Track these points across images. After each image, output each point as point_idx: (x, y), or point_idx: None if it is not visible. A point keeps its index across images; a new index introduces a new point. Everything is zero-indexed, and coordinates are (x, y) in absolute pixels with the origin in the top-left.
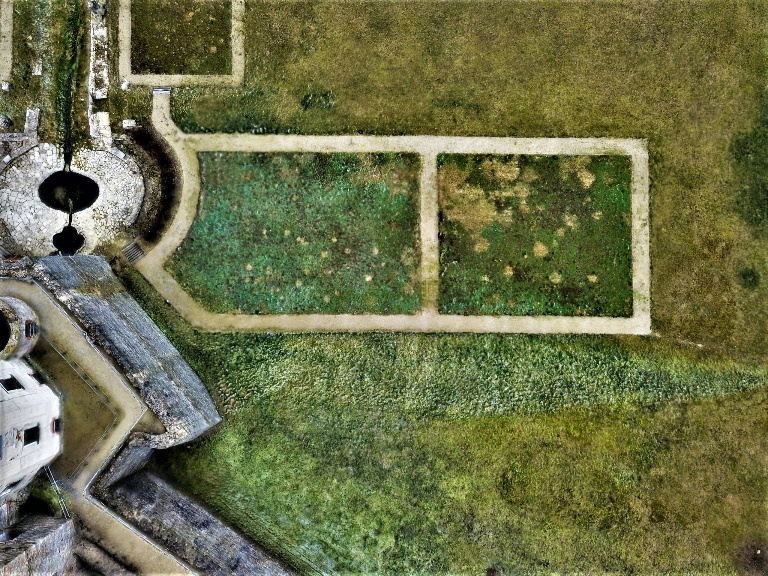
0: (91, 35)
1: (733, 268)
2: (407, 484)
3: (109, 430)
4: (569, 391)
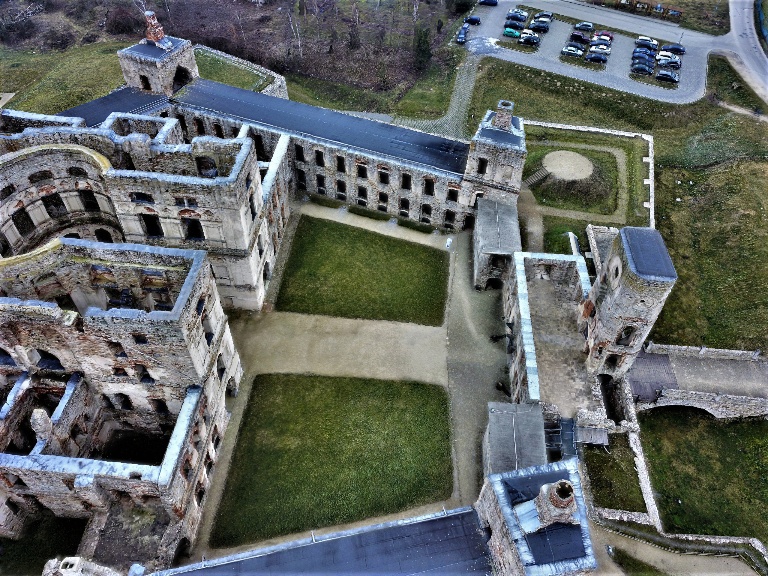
0: None
1: (6, 69)
2: None
3: None
4: None
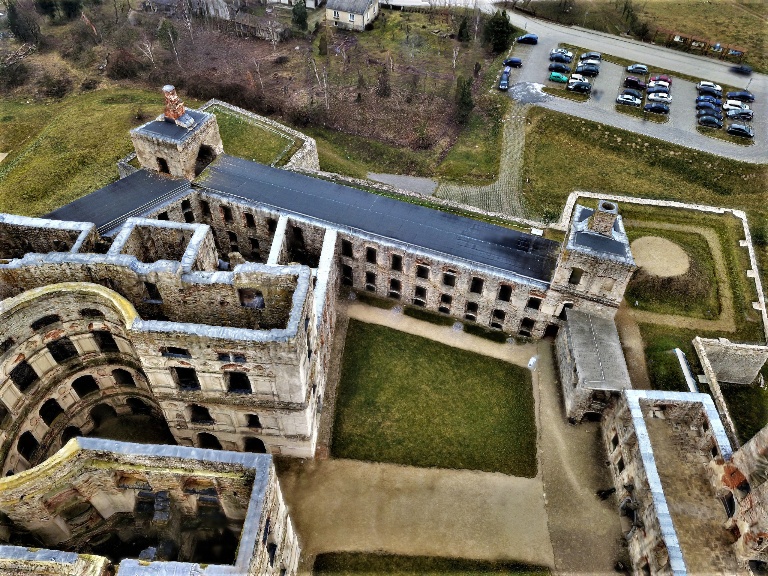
0: None
1: None
2: None
3: None
4: (2, 175)
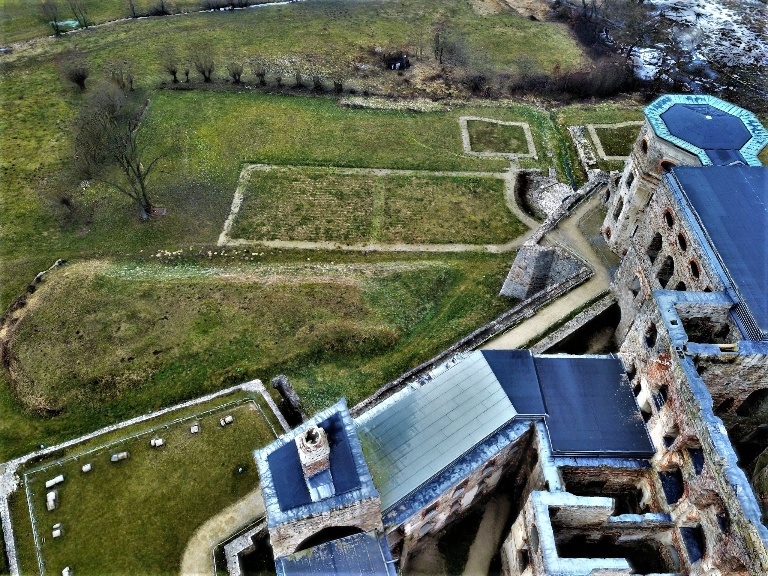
0: (577, 143)
1: None
2: None
3: None
4: None
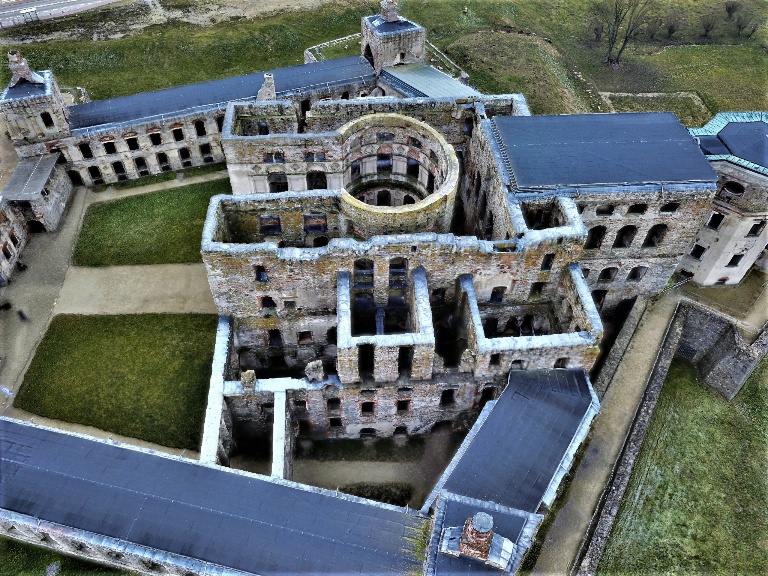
0: None
1: None
2: (753, 567)
3: (727, 313)
4: None
